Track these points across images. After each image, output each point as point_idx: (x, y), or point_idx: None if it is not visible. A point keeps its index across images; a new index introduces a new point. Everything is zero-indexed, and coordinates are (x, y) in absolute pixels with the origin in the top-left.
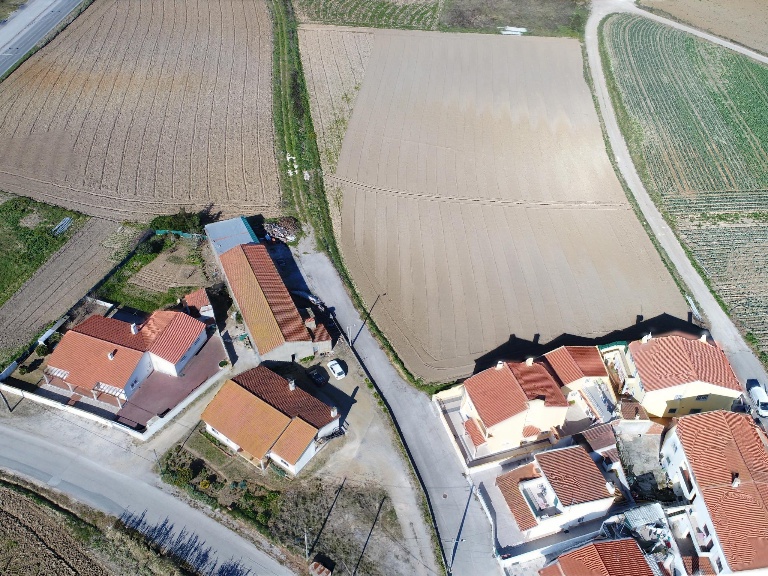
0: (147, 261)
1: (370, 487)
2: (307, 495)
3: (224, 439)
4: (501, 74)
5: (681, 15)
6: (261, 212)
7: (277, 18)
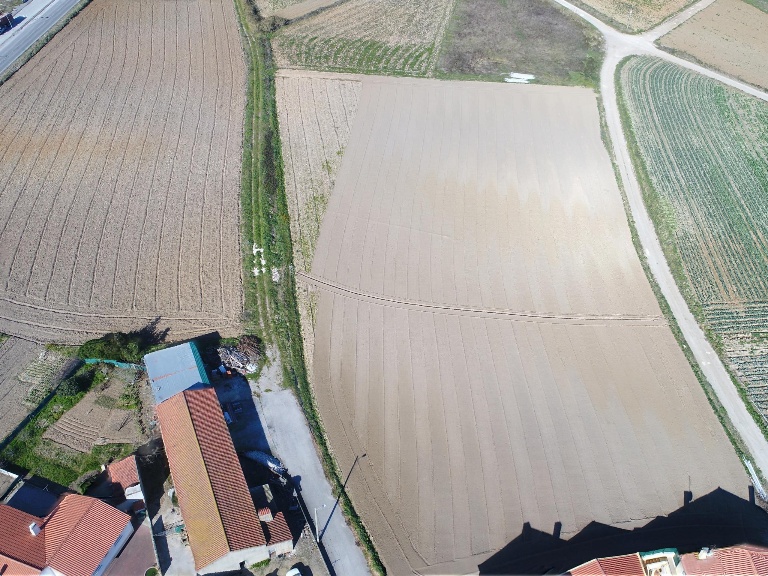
0: (70, 404)
1: None
2: None
3: None
4: (506, 135)
5: (707, 58)
6: (217, 328)
7: (253, 62)
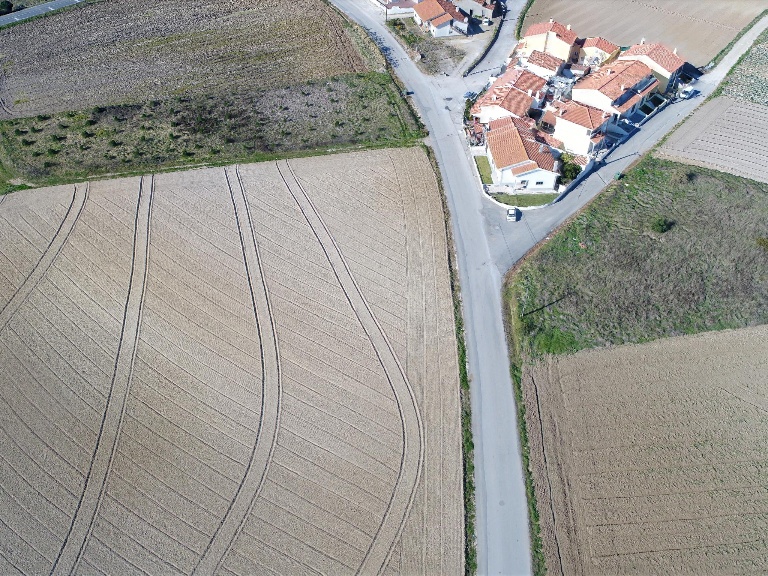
0: None
1: (461, 50)
2: (434, 43)
3: (417, 19)
4: None
5: None
6: None
7: None
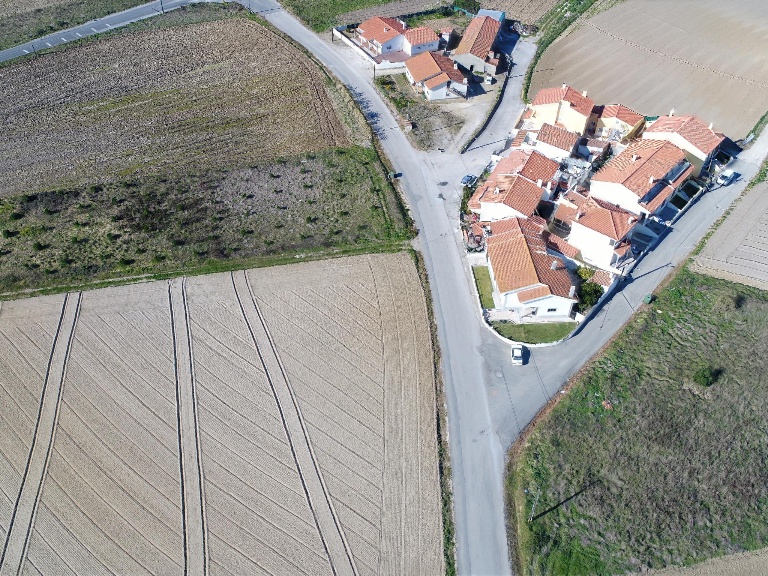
0: (439, 17)
1: (459, 117)
2: (428, 108)
3: (410, 77)
4: None
5: None
6: (521, 20)
7: None
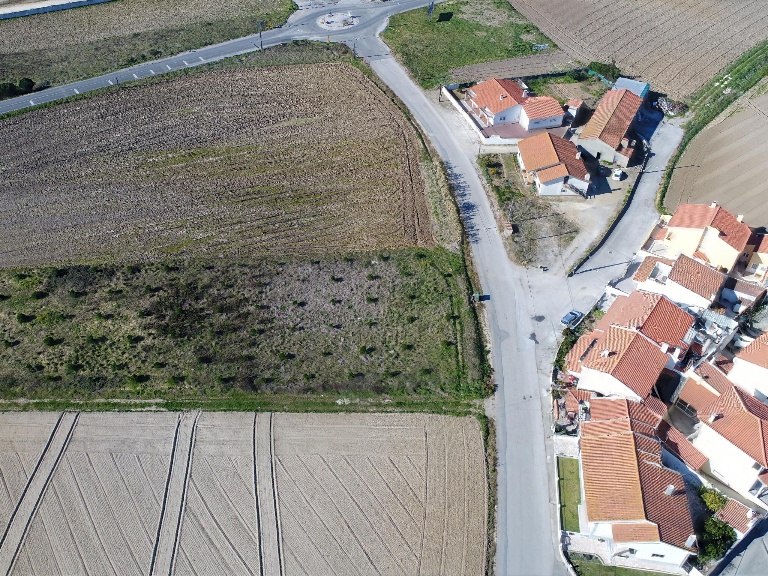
0: (569, 82)
1: (573, 223)
2: (537, 205)
3: None
4: None
5: None
6: (668, 94)
7: None
